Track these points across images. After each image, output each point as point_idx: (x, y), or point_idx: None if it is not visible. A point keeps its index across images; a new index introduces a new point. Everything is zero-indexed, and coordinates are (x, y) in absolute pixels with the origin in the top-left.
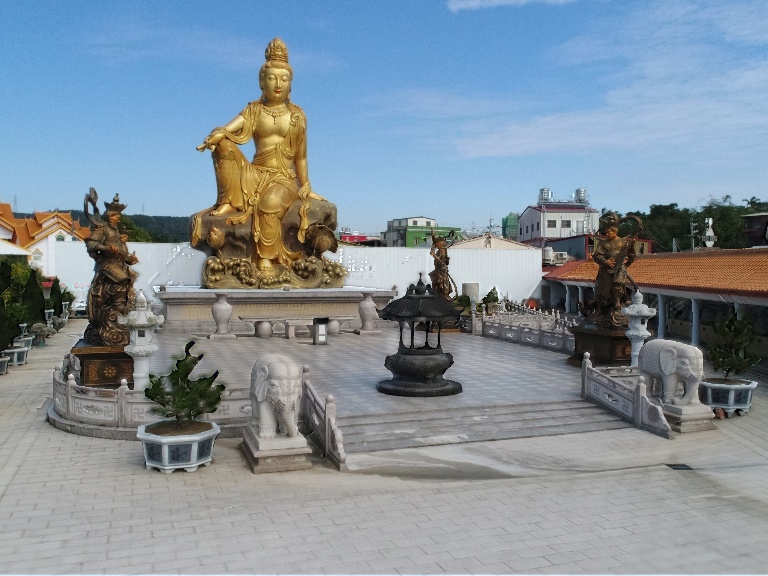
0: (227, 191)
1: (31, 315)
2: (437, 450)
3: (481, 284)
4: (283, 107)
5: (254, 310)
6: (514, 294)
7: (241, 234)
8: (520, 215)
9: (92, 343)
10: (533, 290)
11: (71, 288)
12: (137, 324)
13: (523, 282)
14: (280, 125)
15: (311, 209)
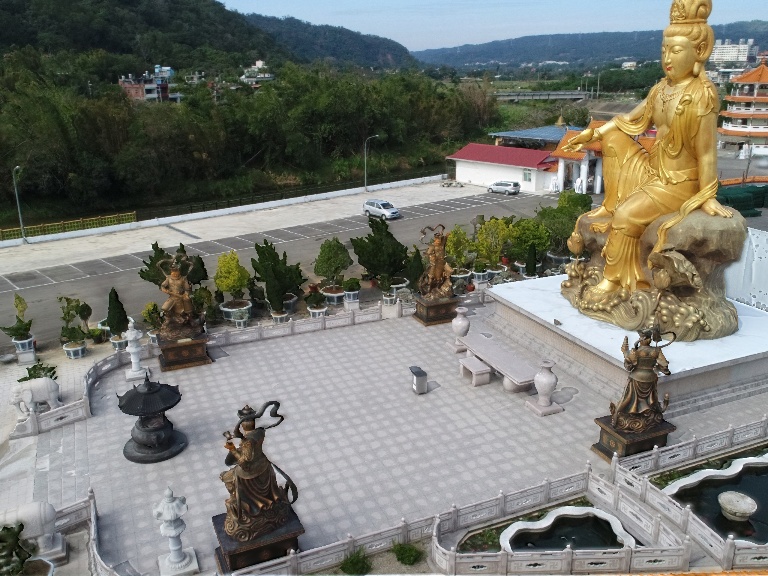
0: None
1: None
2: (27, 462)
3: None
4: (683, 86)
5: (542, 331)
6: None
7: (602, 243)
8: None
9: None
10: None
11: None
12: None
13: None
14: (667, 113)
15: (673, 229)
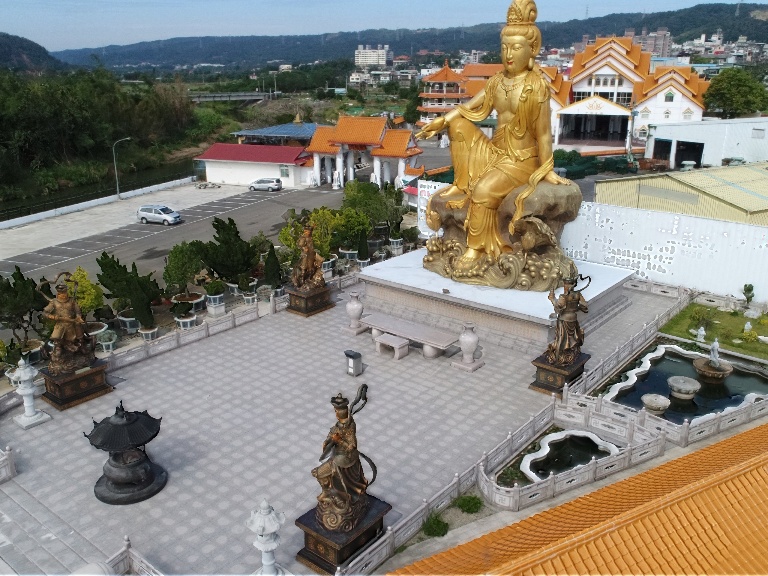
0: None
1: (268, 277)
2: None
3: None
4: (521, 78)
5: (425, 302)
6: None
7: (459, 218)
8: None
9: None
10: None
11: None
12: (11, 378)
13: None
14: (511, 101)
15: (529, 198)
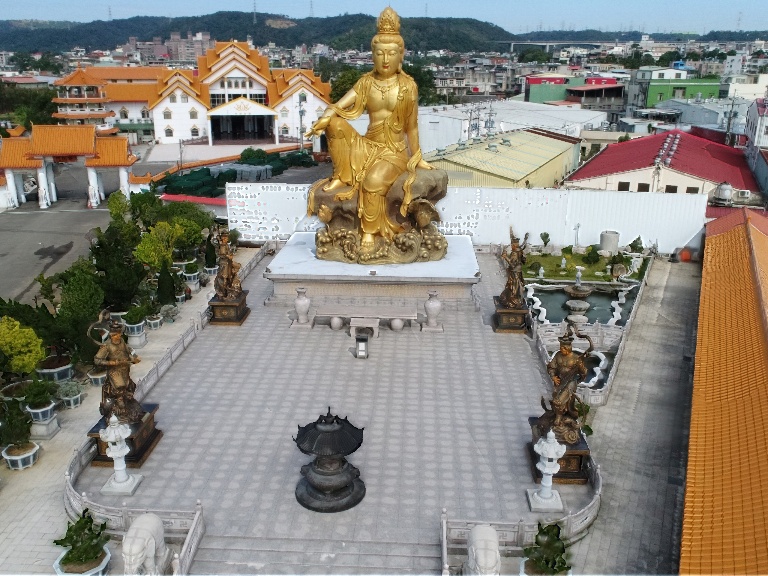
0: (337, 167)
1: (164, 296)
2: None
3: (628, 229)
4: (393, 80)
5: (346, 288)
6: (667, 241)
7: (348, 208)
8: (750, 104)
9: (105, 425)
10: (691, 238)
11: (240, 222)
12: (107, 441)
13: (679, 229)
14: (388, 100)
15: (415, 183)
